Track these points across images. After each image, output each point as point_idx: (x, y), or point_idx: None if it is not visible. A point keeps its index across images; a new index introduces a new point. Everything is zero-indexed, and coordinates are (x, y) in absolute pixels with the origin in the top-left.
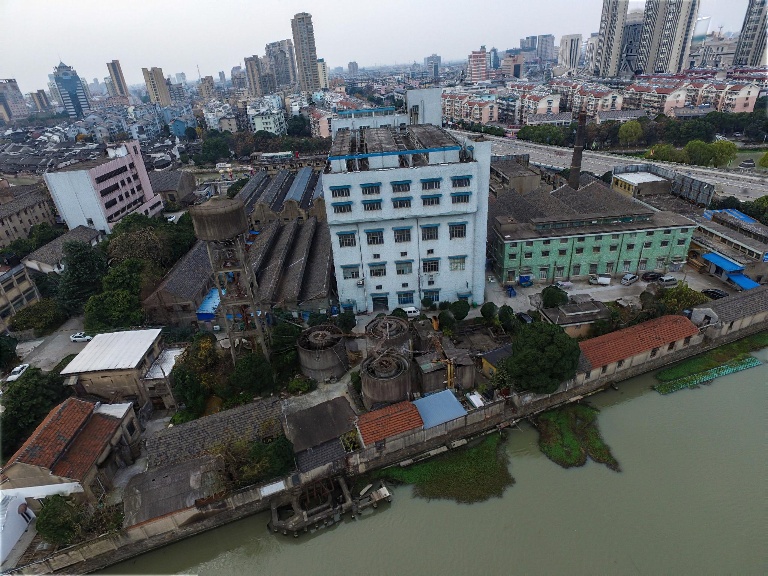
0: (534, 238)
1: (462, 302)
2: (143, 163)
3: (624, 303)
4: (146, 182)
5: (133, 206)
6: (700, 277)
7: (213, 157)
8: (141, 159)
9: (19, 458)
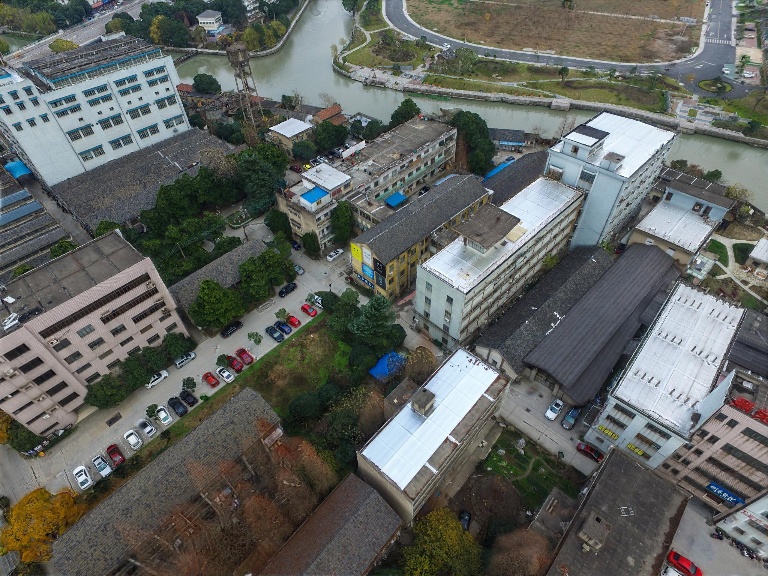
0: None
1: None
2: None
3: None
4: None
5: None
6: None
7: None
8: None
9: None
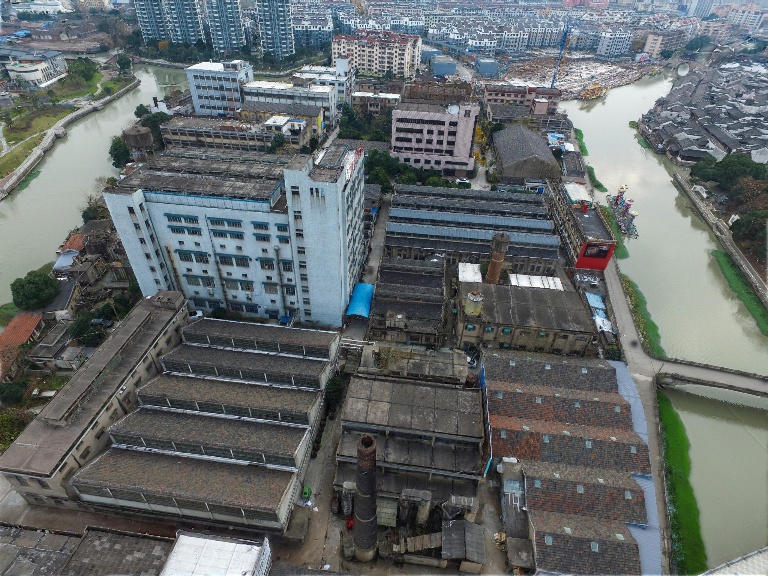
0: (130, 313)
1: (132, 282)
2: (472, 127)
3: (48, 394)
4: (465, 143)
5: (436, 153)
6: (4, 515)
7: (703, 175)
8: (472, 123)
9: (128, 166)
